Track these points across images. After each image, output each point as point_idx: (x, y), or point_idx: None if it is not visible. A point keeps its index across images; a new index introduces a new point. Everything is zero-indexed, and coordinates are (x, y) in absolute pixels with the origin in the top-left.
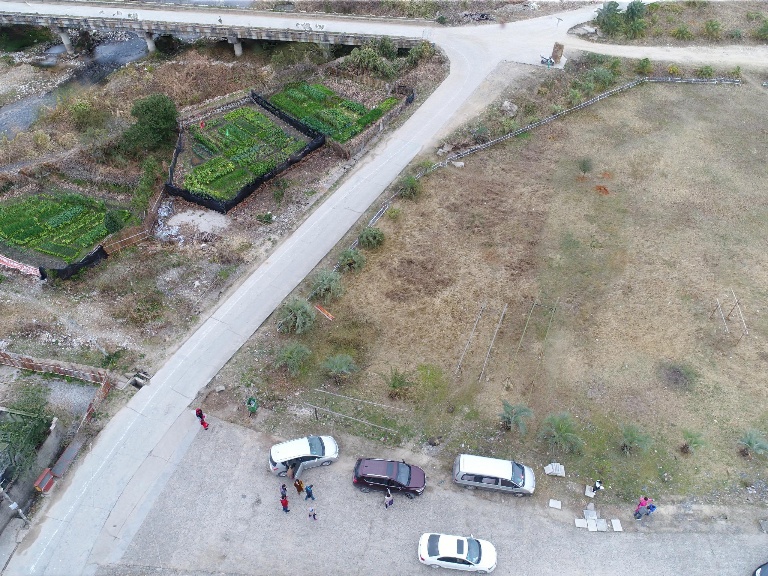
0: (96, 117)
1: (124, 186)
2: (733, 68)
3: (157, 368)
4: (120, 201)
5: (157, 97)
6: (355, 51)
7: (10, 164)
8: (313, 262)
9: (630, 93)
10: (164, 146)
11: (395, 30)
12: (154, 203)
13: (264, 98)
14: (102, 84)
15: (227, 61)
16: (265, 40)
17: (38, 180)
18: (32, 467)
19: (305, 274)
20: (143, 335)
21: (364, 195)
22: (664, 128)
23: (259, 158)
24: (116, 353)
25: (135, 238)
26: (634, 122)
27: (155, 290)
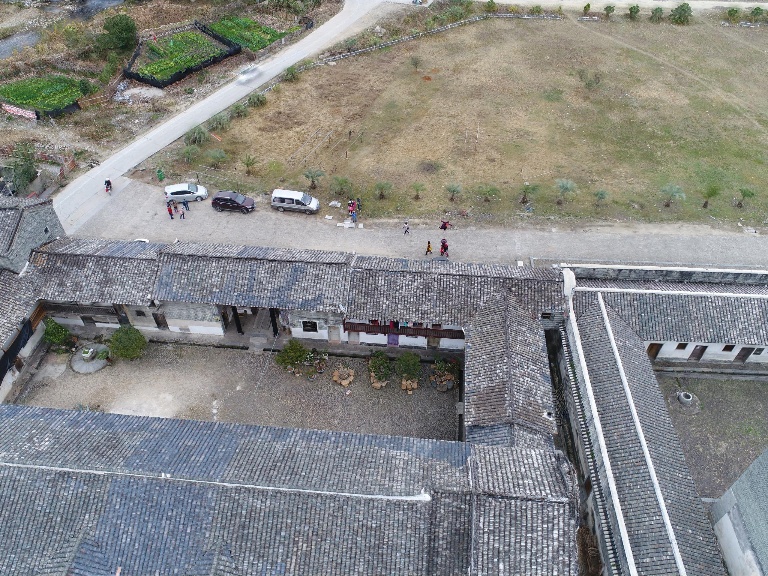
0: None
1: (96, 73)
2: (561, 9)
3: (105, 159)
4: (93, 83)
5: (121, 15)
6: None
7: None
8: (215, 112)
9: (476, 24)
10: (127, 52)
11: None
12: (115, 80)
13: (205, 26)
14: (89, 21)
15: (184, 5)
16: None
17: (38, 69)
18: (26, 188)
19: (208, 118)
20: (99, 144)
21: (260, 79)
22: (490, 45)
23: (193, 60)
24: (81, 152)
25: (100, 99)
26: (470, 41)
27: (109, 124)
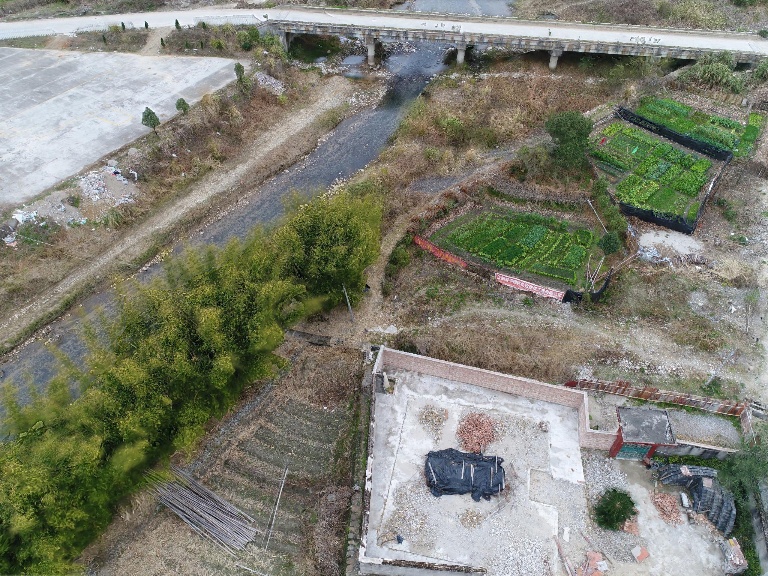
0: (480, 132)
1: (569, 205)
2: None
3: (767, 398)
4: (569, 220)
5: None
6: (698, 65)
7: (415, 180)
8: None
9: None
10: None
11: (720, 44)
12: None
13: (626, 113)
14: (425, 96)
15: (545, 74)
16: (592, 53)
17: (477, 198)
18: None
19: None
20: (724, 363)
21: None
22: None
23: (674, 176)
24: (714, 382)
25: (628, 260)
26: None
27: (697, 315)
